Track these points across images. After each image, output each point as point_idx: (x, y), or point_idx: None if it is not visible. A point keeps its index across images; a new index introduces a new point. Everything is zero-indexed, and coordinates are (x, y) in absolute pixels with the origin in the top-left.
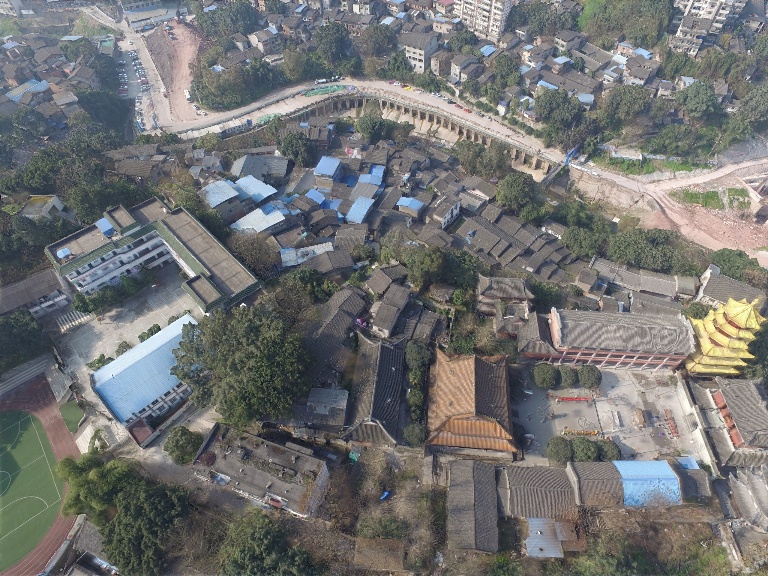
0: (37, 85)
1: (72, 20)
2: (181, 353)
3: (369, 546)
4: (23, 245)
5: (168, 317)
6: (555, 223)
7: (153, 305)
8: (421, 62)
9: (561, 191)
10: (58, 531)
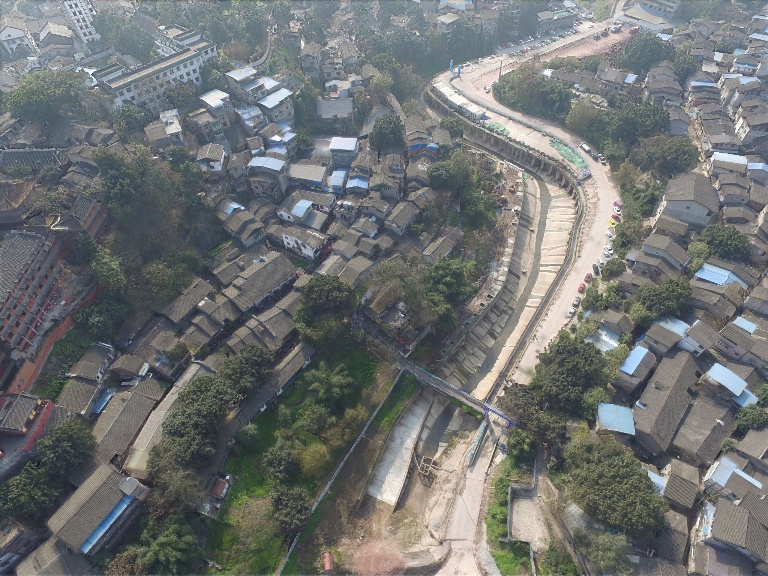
0: (463, 4)
1: None
2: None
3: None
4: None
5: None
6: (303, 355)
7: None
8: None
9: (454, 425)
10: None
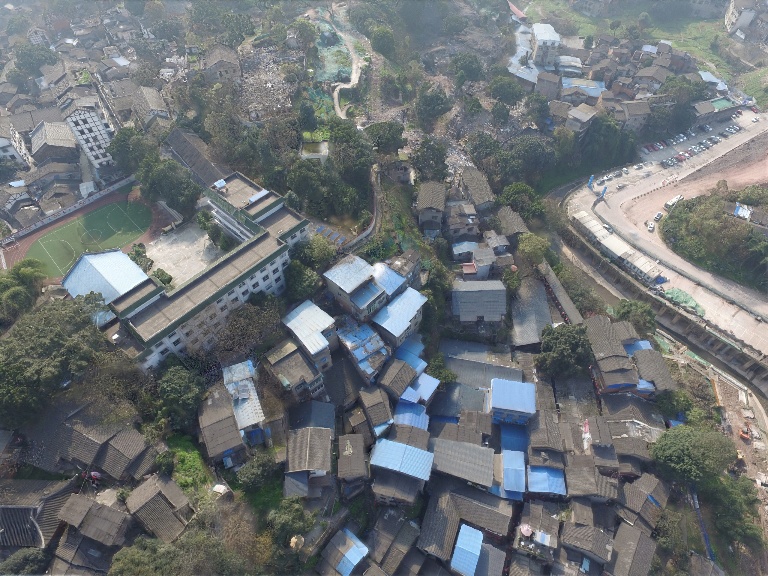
0: (596, 89)
1: (761, 65)
2: None
3: None
4: None
5: None
6: None
7: None
8: None
9: None
10: None
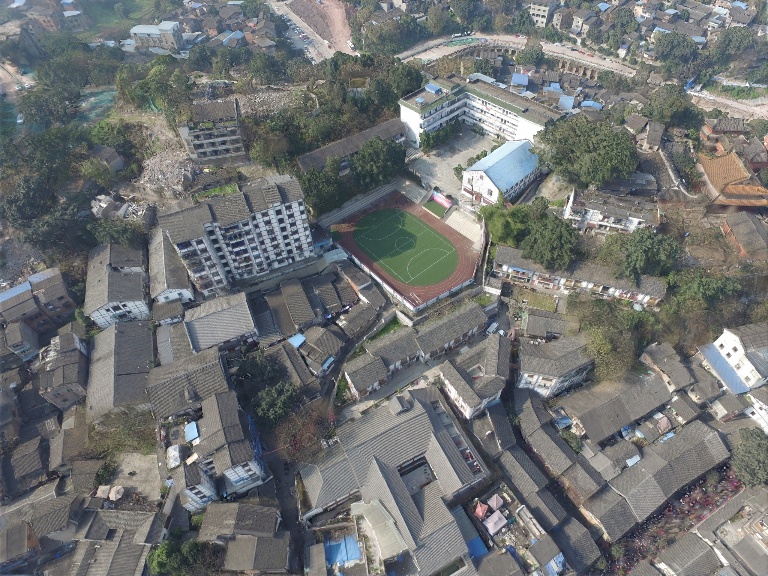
0: (234, 34)
1: None
2: (536, 150)
3: (698, 248)
4: (369, 104)
5: (476, 154)
6: None
7: (460, 148)
8: (544, 18)
9: None
10: (465, 263)
